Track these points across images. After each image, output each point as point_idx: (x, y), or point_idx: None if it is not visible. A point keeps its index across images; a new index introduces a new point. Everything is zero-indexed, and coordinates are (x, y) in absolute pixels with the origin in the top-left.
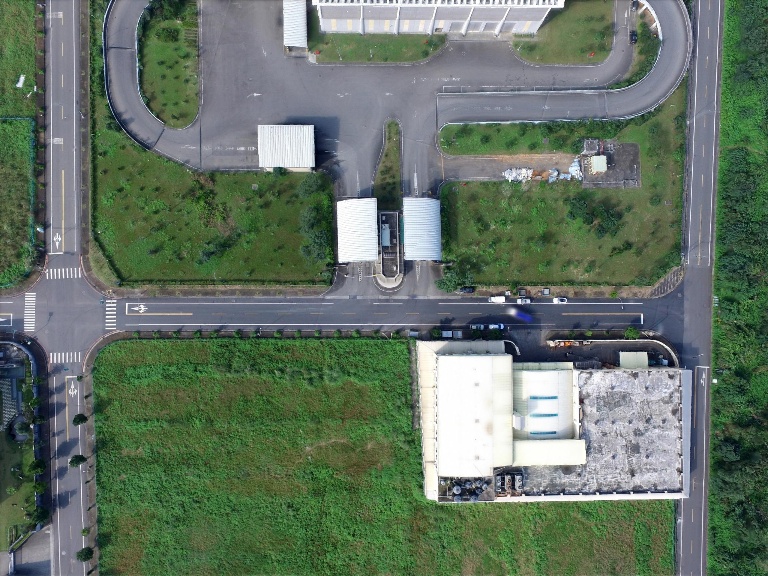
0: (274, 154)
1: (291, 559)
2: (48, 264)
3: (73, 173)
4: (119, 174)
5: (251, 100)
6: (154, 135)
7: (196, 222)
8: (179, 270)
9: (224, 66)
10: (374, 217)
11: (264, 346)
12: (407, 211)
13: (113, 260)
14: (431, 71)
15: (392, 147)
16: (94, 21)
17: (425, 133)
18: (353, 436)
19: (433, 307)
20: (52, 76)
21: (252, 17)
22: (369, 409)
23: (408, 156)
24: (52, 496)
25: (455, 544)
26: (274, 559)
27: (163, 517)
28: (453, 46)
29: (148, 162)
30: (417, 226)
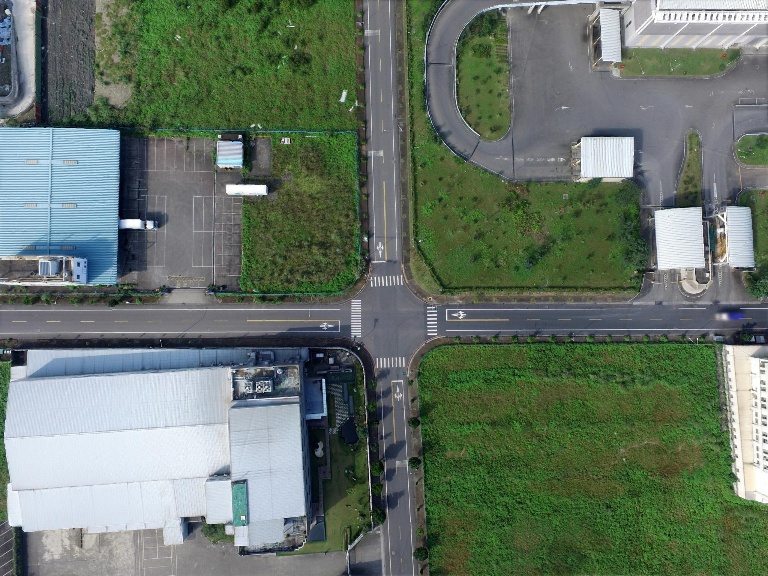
0: (596, 165)
1: (610, 559)
2: (372, 272)
3: (393, 184)
4: (437, 185)
5: (559, 113)
6: (470, 147)
7: (512, 231)
8: (496, 277)
9: (533, 80)
10: (700, 225)
11: (578, 351)
12: (730, 219)
13: (434, 268)
14: (727, 84)
15: (693, 157)
16: (410, 38)
17: (723, 144)
18: (665, 438)
19: (735, 312)
20: (371, 91)
21: (558, 33)
22: (679, 412)
23: (708, 166)
24: (381, 497)
25: (765, 544)
26: (594, 559)
27: (488, 518)
28: (747, 60)
29: (465, 173)
30: (739, 234)
